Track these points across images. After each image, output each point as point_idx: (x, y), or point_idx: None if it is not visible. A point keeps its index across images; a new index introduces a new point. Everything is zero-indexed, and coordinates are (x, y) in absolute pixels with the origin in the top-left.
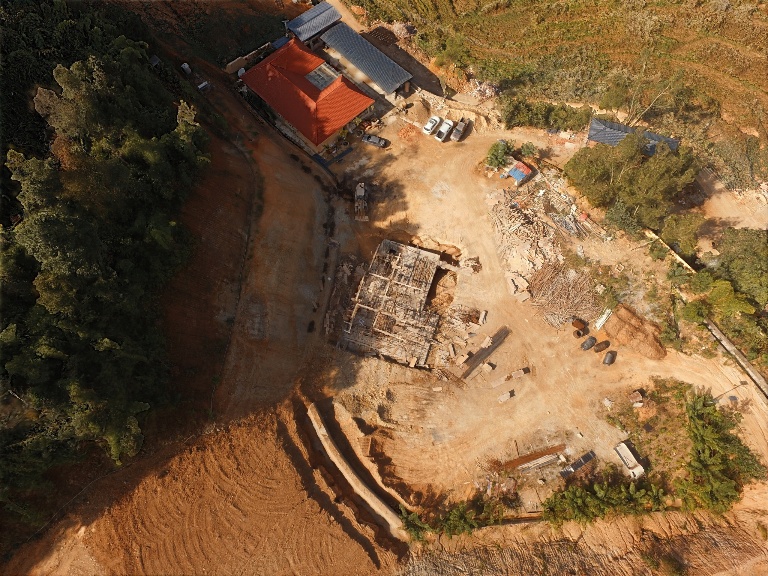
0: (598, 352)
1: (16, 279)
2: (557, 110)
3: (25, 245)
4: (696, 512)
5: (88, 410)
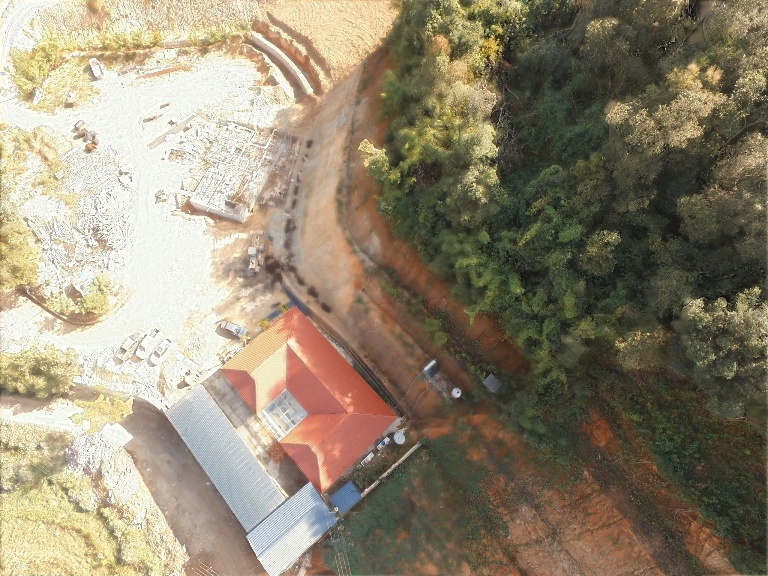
0: None
1: None
2: (6, 363)
3: None
4: None
5: None
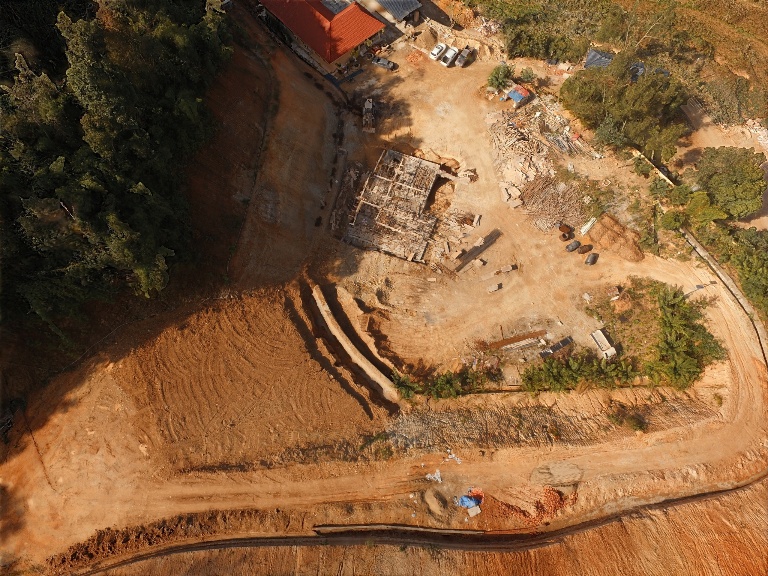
0: (581, 254)
1: (63, 124)
2: (557, 41)
3: (74, 87)
4: (661, 389)
5: (124, 238)
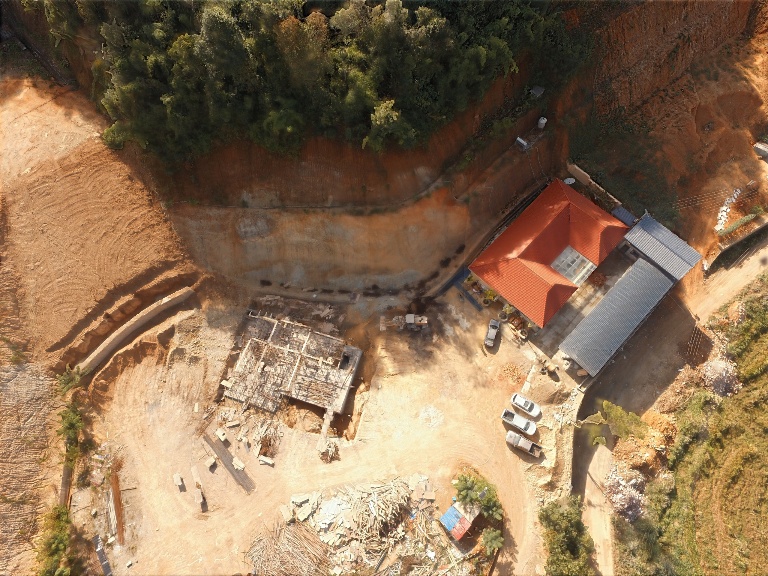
0: None
1: None
2: None
3: None
4: None
5: None
